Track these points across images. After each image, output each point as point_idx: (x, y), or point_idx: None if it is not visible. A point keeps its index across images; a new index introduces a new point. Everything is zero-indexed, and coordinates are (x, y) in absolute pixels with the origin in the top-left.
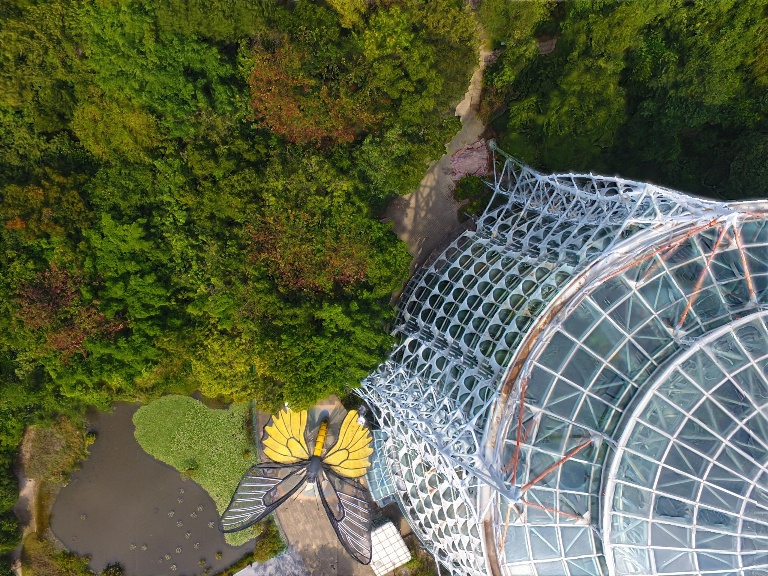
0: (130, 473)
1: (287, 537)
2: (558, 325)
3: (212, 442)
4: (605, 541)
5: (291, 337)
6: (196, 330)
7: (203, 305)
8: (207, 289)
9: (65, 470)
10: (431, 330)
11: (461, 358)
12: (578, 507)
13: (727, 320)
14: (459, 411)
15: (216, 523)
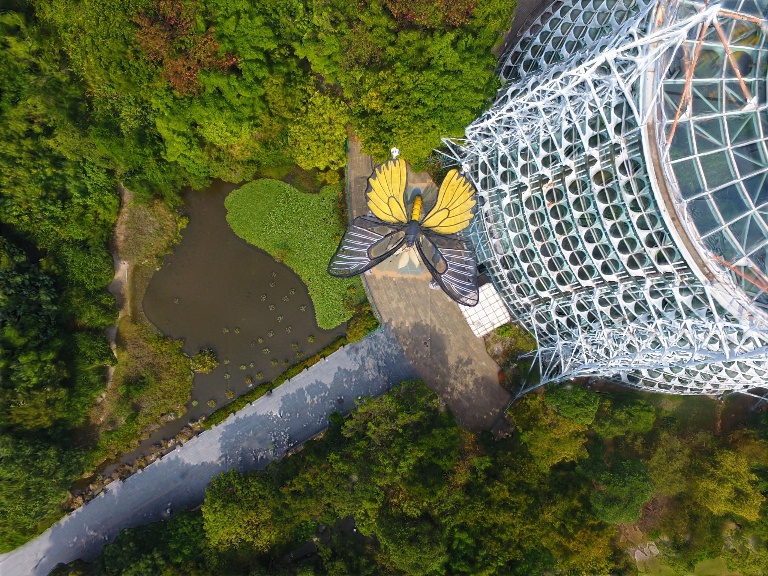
0: (222, 258)
1: (380, 315)
2: None
3: (303, 226)
4: None
5: None
6: (297, 88)
7: None
8: (319, 22)
9: (158, 254)
10: (540, 64)
11: (586, 51)
12: (743, 98)
13: None
14: (607, 49)
15: (308, 307)
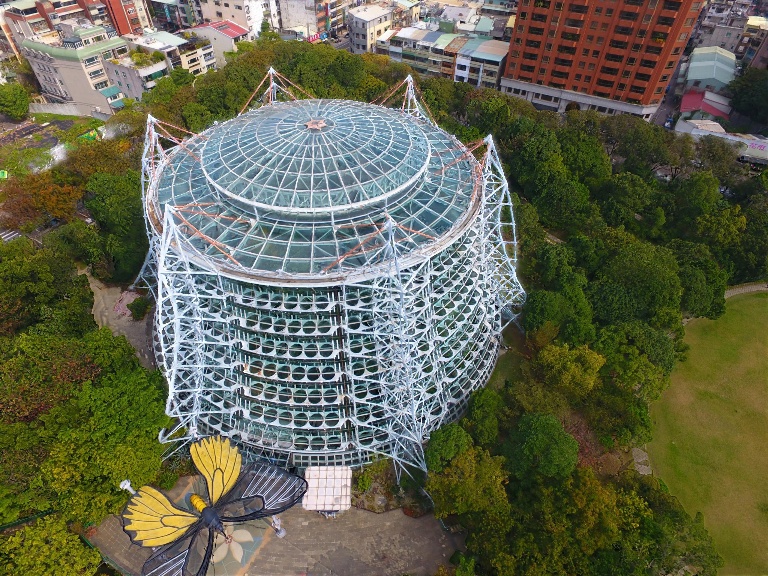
0: None
1: None
2: (152, 198)
3: None
4: (251, 203)
5: (68, 430)
6: None
7: None
8: None
9: None
10: None
11: None
12: None
13: None
14: (169, 277)
15: None
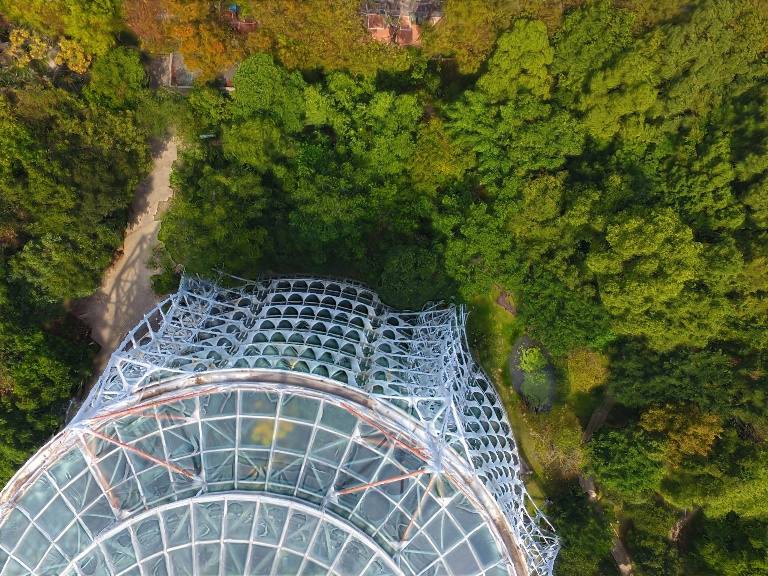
0: None
1: None
2: (0, 506)
3: None
4: None
5: None
6: None
7: None
8: None
9: None
10: None
11: None
12: None
13: (172, 500)
14: None
15: None
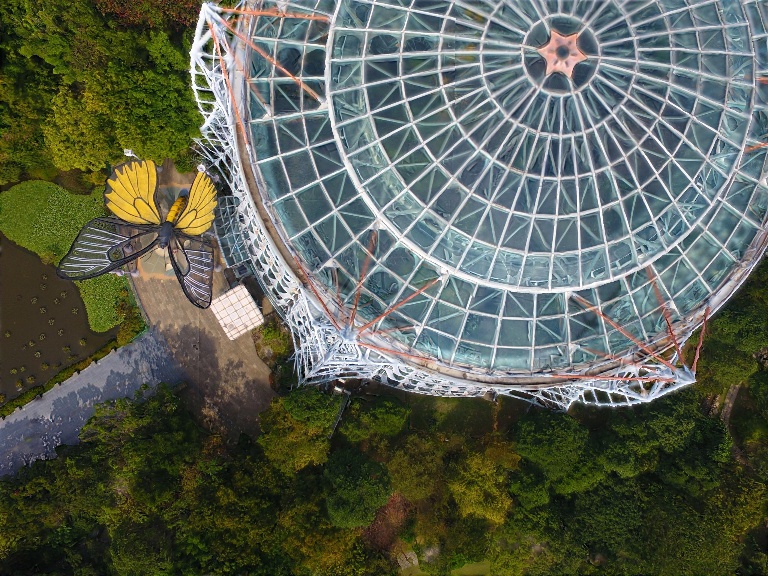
0: None
1: (148, 317)
2: None
3: (74, 228)
4: (326, 91)
5: (118, 66)
6: (40, 88)
7: (37, 48)
8: (34, 21)
9: None
10: None
11: None
12: (322, 97)
13: None
14: None
15: (80, 310)
